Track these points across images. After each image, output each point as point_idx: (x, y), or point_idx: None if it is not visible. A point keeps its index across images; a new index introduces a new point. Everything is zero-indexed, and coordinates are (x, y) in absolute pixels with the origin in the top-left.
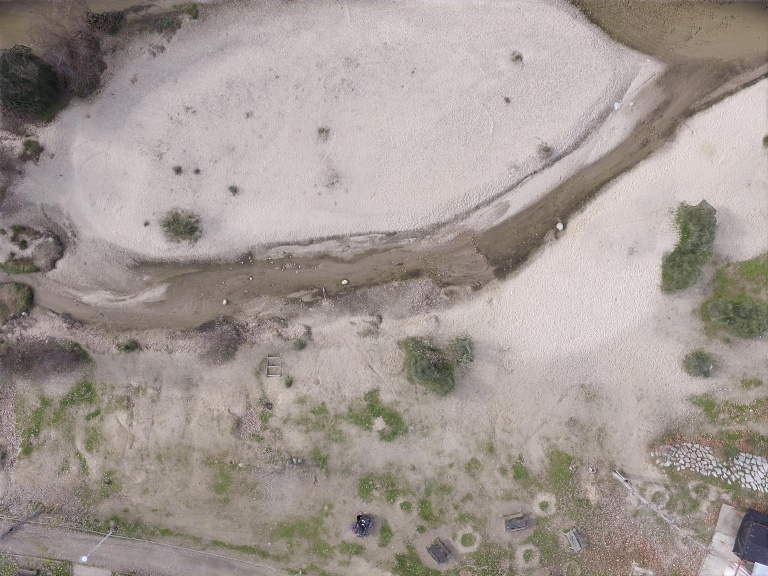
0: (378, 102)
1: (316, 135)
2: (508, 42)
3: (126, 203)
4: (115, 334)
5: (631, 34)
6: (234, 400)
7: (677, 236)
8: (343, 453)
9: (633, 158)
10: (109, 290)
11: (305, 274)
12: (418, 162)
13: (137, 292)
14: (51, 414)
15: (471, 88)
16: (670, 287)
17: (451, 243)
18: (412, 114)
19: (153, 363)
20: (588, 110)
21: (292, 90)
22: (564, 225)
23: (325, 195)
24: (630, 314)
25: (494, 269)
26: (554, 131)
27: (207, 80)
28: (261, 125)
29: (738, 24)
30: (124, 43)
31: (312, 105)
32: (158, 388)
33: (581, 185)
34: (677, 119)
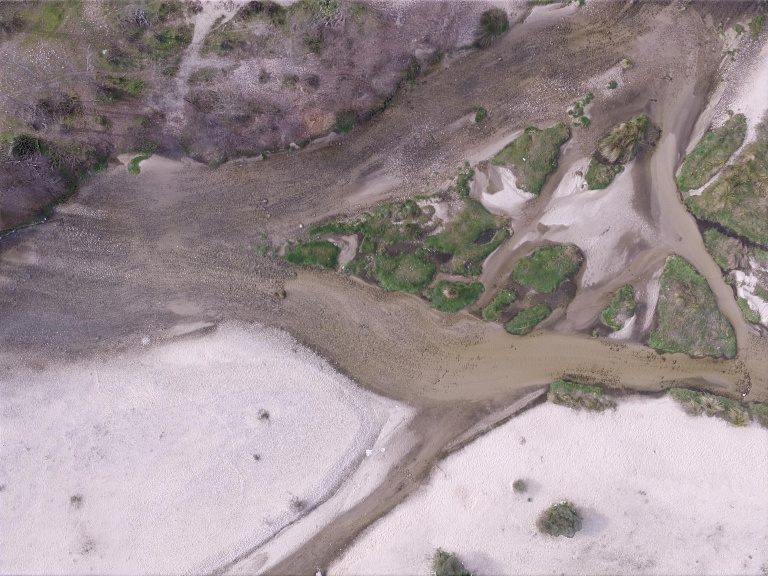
0: (128, 467)
1: (68, 504)
2: (253, 401)
3: None
4: None
5: (378, 381)
6: None
7: None
8: None
9: (389, 502)
10: None
11: None
12: (171, 524)
13: None
14: None
15: (219, 448)
16: None
17: None
18: (162, 477)
19: None
20: (338, 461)
21: (43, 461)
22: (323, 574)
23: (80, 562)
24: None
25: None
26: (305, 485)
27: None
28: (14, 497)
29: (485, 364)
30: None
31: (63, 475)
32: None
33: (338, 532)
34: (430, 462)
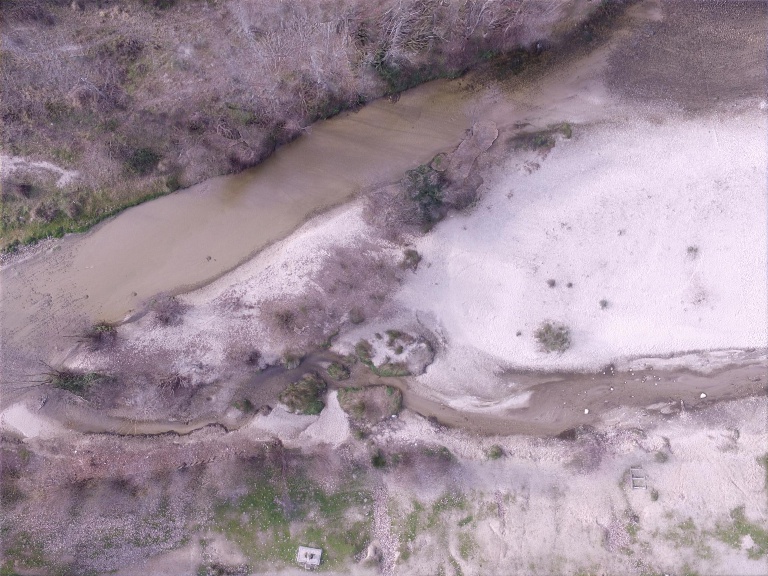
0: (745, 224)
1: (685, 253)
2: None
3: (499, 313)
4: (478, 439)
5: None
6: (600, 511)
7: None
8: (712, 570)
9: None
10: (475, 396)
11: (664, 386)
12: None
13: (502, 398)
14: (425, 519)
15: None
16: None
17: None
18: None
19: (520, 470)
20: None
21: (663, 210)
22: None
23: (691, 311)
24: None
25: None
26: None
27: (581, 198)
28: (632, 242)
29: None
30: (500, 159)
31: (682, 225)
32: (526, 496)
33: None
34: None
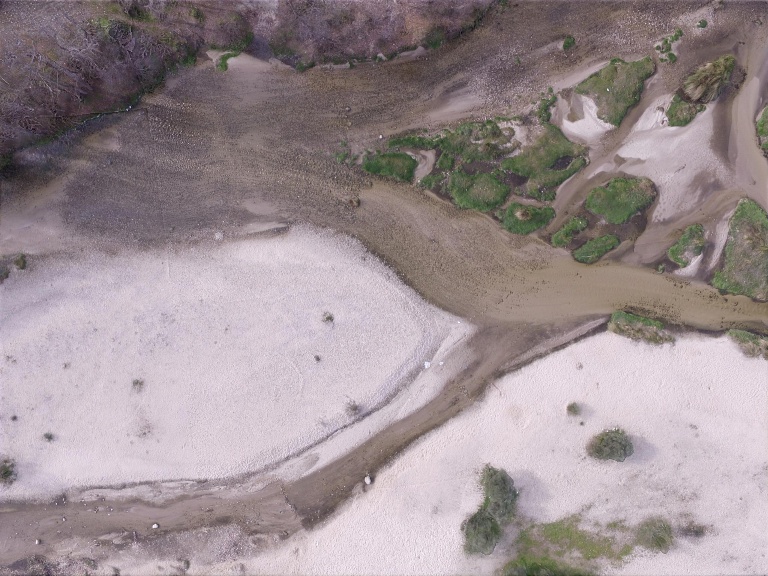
0: (191, 357)
1: (130, 386)
2: (320, 303)
3: None
4: None
5: (443, 296)
6: None
7: (481, 497)
8: None
9: (442, 416)
10: None
11: (117, 517)
12: (228, 415)
13: None
14: None
15: (282, 346)
16: (471, 550)
17: (261, 492)
18: (224, 369)
19: None
20: (397, 370)
21: (109, 343)
22: (372, 479)
23: (137, 444)
24: (433, 572)
25: (302, 519)
26: (362, 390)
27: (28, 330)
28: (78, 375)
29: (549, 289)
30: None
31: (128, 358)
32: None
33: (390, 440)
34: (486, 379)
